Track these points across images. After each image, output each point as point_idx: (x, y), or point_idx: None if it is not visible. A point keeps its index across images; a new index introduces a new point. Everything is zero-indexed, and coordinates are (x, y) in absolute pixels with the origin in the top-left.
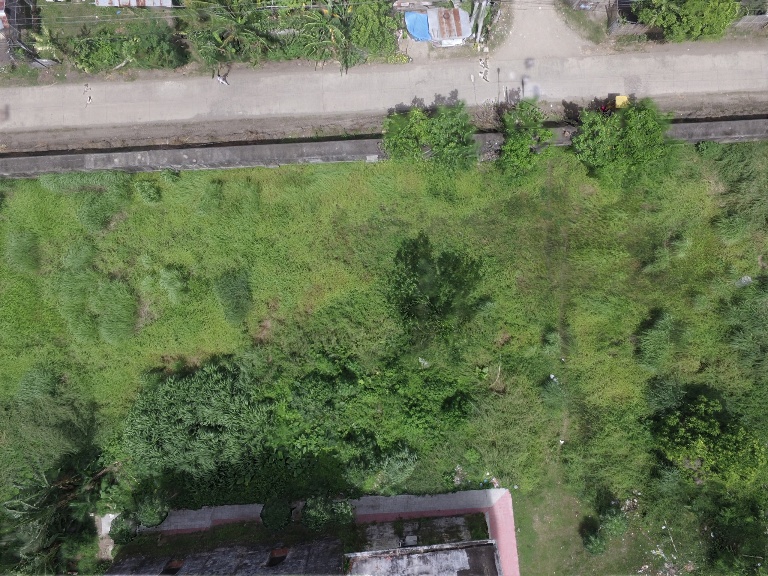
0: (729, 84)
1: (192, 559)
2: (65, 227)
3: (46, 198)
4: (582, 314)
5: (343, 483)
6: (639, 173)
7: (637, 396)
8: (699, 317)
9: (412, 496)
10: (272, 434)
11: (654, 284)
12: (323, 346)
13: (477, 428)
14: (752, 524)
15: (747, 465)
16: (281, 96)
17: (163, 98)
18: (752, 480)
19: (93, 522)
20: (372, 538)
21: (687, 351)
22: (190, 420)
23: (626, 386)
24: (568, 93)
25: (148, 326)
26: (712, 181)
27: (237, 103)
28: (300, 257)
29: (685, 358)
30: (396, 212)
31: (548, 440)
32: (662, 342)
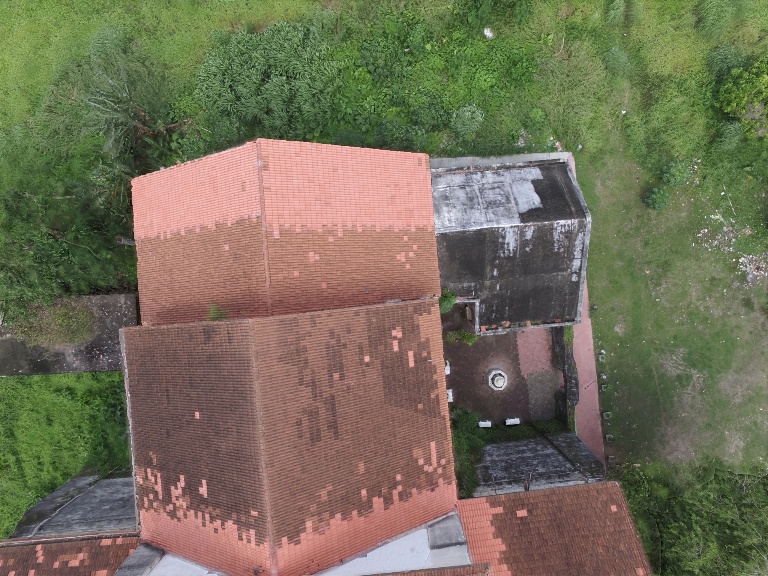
0: None
1: None
2: None
3: None
4: None
5: None
6: None
7: (698, 64)
8: None
9: (477, 158)
10: (340, 94)
11: None
12: (391, 12)
13: (542, 90)
14: None
15: None
16: None
17: None
18: None
19: None
20: None
21: (748, 21)
22: (263, 65)
23: (688, 55)
24: None
25: None
26: None
27: None
28: None
29: (746, 26)
30: None
31: (610, 109)
32: (725, 5)
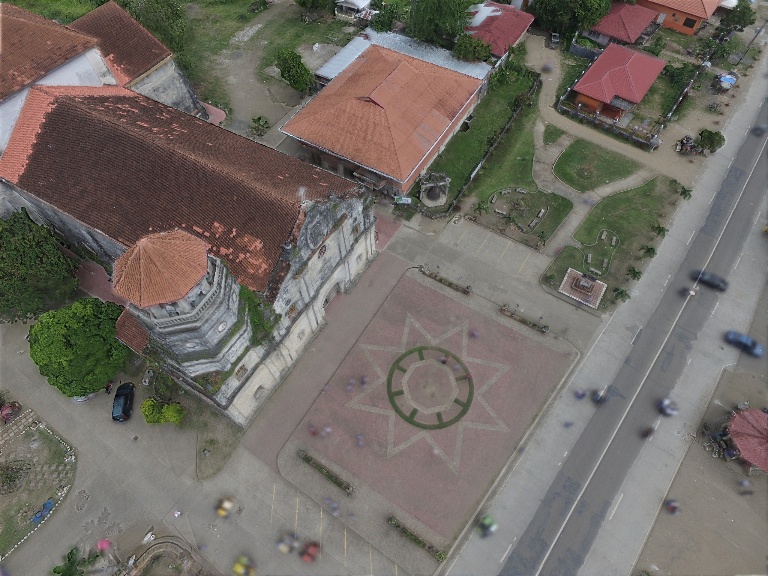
0: None
1: None
2: None
3: None
4: (54, 8)
5: None
6: None
7: None
8: None
9: None
10: None
11: None
12: None
13: None
14: None
15: None
16: None
17: None
18: None
19: None
20: None
21: None
22: None
23: (85, 9)
24: None
25: None
26: None
27: None
28: None
29: None
30: None
31: None
32: None
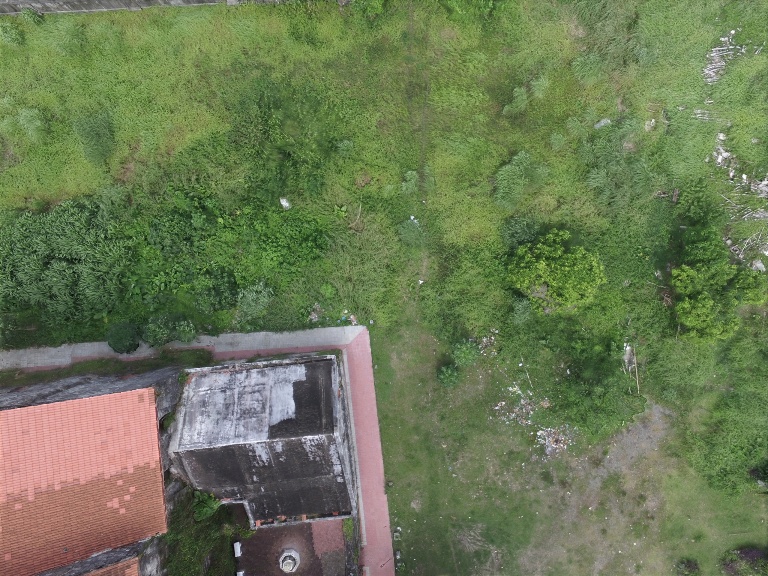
0: None
1: (42, 384)
2: None
3: None
4: (442, 155)
5: (199, 317)
6: (499, 16)
7: (494, 234)
8: (558, 158)
9: (270, 333)
10: (131, 271)
11: (514, 127)
12: (183, 185)
13: (334, 264)
14: (607, 360)
15: (584, 280)
16: None
17: None
18: (590, 297)
19: None
20: None
21: (544, 190)
22: (44, 250)
23: (483, 225)
24: None
25: (11, 167)
26: (572, 26)
27: None
28: (162, 99)
29: (541, 196)
30: (259, 56)
31: (407, 279)
32: (516, 177)
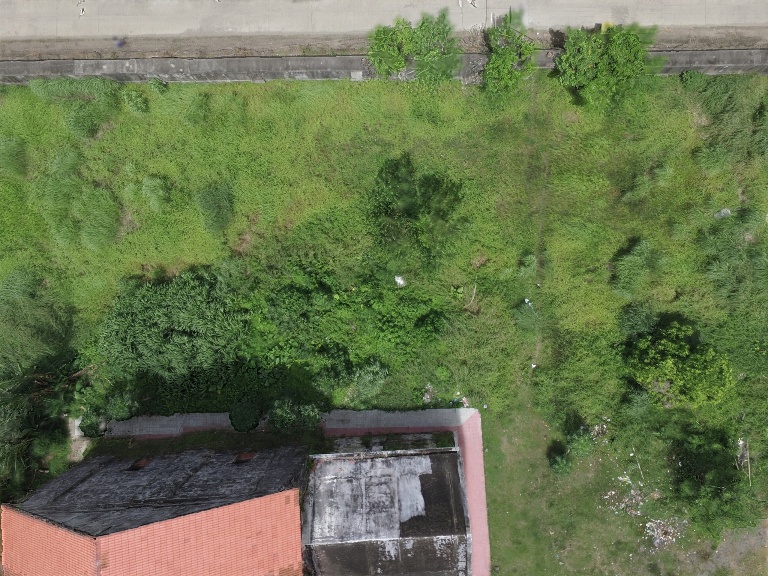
0: (717, 18)
1: (160, 458)
2: (53, 134)
3: (35, 105)
4: (559, 240)
5: (314, 394)
6: (622, 102)
7: (610, 322)
8: (676, 247)
9: (382, 412)
10: (246, 344)
11: (633, 213)
12: (300, 260)
13: (449, 347)
14: (721, 455)
15: (714, 384)
16: (270, 14)
17: (154, 12)
18: (719, 400)
19: (67, 424)
20: (339, 447)
21: (662, 280)
22: (165, 323)
23: (600, 312)
24: (555, 22)
25: (129, 234)
26: (695, 113)
27: (227, 20)
28: (282, 172)
29: (660, 286)
30: (379, 132)
31: (520, 363)
32: (637, 268)
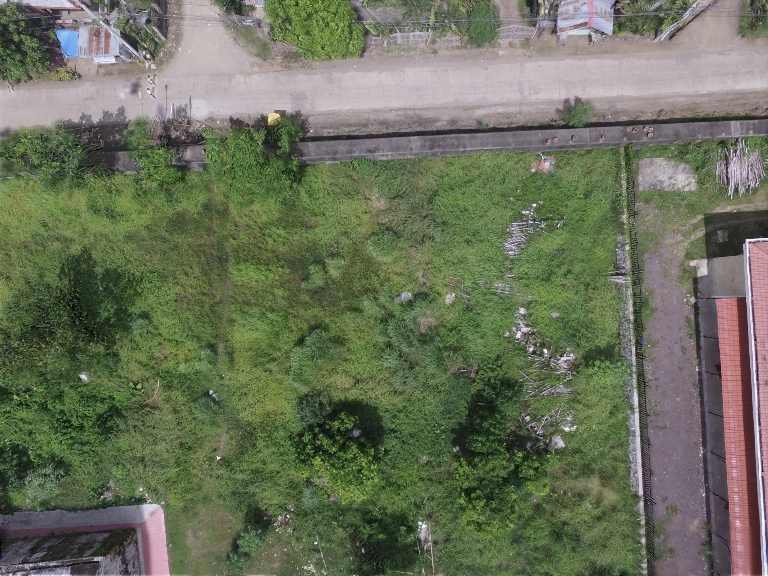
0: (395, 101)
1: None
2: None
3: None
4: (240, 330)
5: None
6: (298, 190)
7: (289, 412)
8: (357, 333)
9: (64, 512)
10: None
11: (314, 300)
12: None
13: (127, 444)
14: None
15: (351, 483)
16: None
17: None
18: (360, 498)
19: None
20: (6, 554)
21: (339, 367)
22: None
23: (279, 402)
24: (235, 110)
25: None
26: (374, 197)
27: None
28: None
29: (335, 374)
30: (58, 228)
31: (204, 456)
32: (307, 359)
